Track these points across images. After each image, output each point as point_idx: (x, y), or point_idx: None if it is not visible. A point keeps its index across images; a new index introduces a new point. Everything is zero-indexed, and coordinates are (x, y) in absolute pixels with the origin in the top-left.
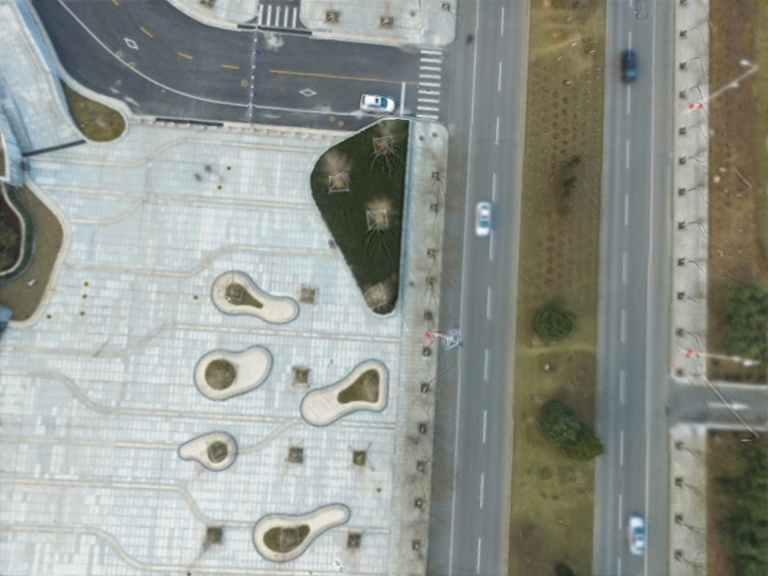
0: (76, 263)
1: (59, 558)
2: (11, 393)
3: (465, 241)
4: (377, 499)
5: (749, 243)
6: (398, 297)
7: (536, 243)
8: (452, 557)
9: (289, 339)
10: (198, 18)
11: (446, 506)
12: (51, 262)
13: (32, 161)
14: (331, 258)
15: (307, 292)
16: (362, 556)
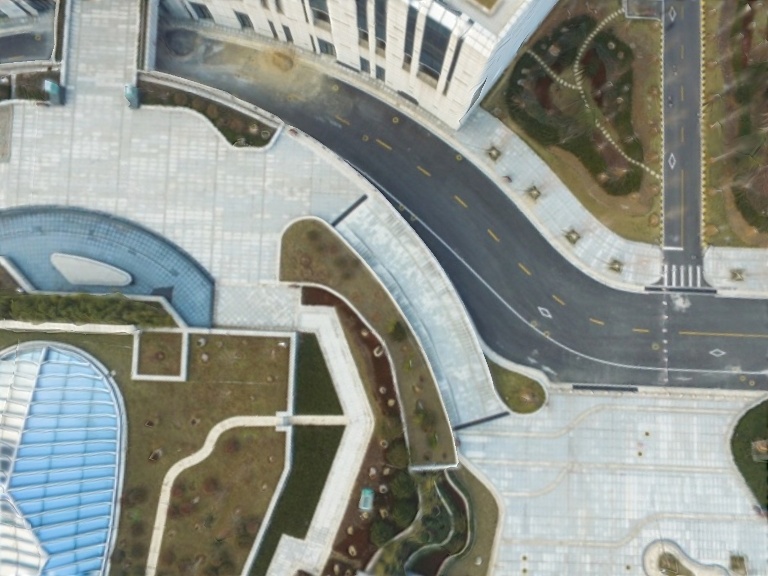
0: (513, 537)
1: None
2: None
3: None
4: None
5: None
6: None
7: None
8: None
9: None
10: (606, 282)
11: None
12: (491, 538)
13: (461, 435)
14: (756, 523)
15: (736, 560)
16: None
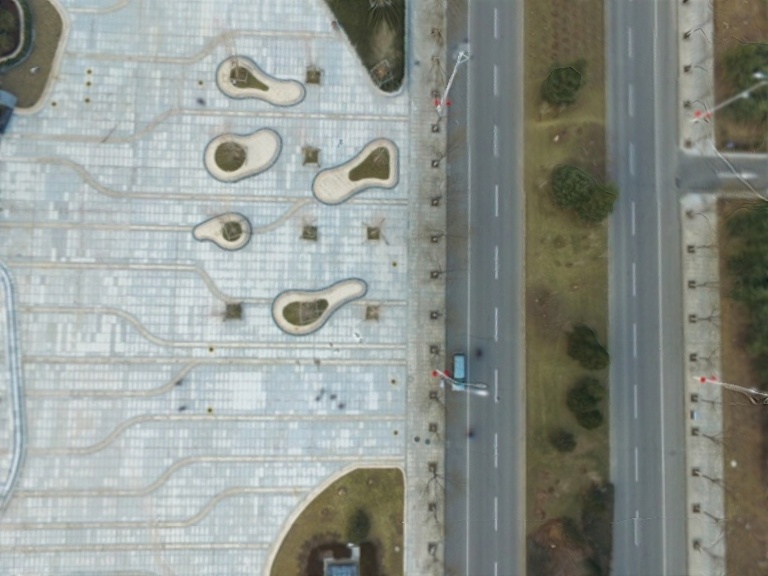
0: (77, 52)
1: (81, 337)
2: (21, 180)
3: (469, 21)
4: (393, 273)
5: (755, 14)
6: (404, 75)
7: (541, 19)
8: (470, 326)
9: (297, 121)
10: None
11: (462, 278)
12: (52, 50)
13: None
14: (335, 41)
15: (312, 74)
16: (381, 326)
